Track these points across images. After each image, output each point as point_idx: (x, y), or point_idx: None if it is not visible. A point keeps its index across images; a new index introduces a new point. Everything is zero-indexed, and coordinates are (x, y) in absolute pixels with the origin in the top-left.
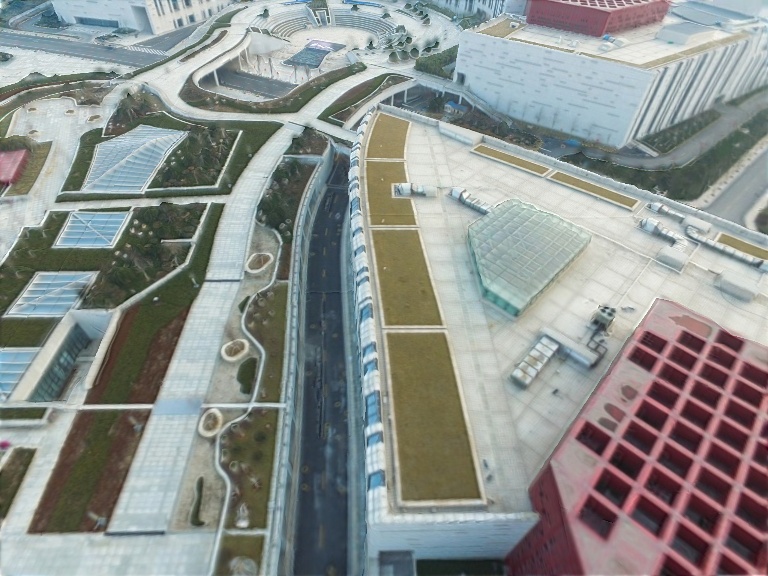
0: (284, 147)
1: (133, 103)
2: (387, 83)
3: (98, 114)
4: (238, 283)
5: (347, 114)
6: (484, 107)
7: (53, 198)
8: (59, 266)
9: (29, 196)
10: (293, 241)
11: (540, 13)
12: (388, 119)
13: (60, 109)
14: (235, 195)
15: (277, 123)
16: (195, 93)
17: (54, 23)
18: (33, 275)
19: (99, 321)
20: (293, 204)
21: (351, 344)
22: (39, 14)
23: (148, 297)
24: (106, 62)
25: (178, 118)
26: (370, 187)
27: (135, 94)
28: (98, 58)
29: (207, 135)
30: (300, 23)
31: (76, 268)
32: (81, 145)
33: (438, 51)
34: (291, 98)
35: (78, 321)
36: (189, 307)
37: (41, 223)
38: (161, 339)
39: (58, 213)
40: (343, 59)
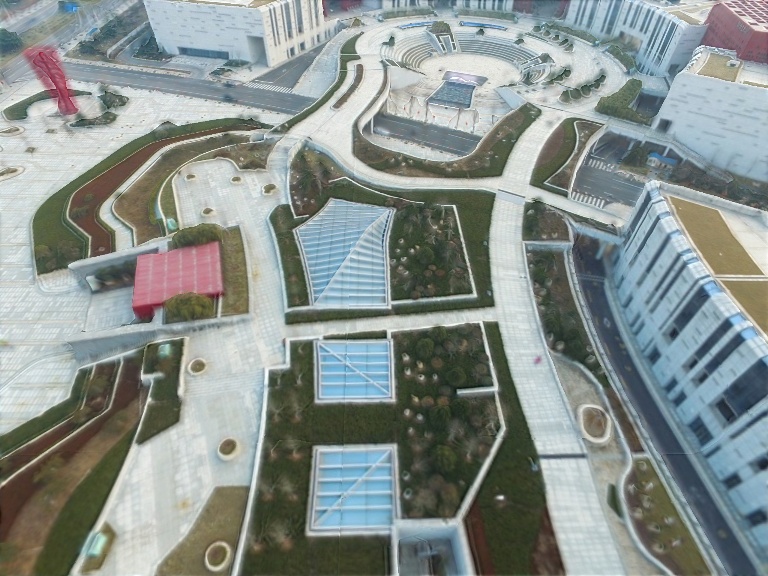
0: (516, 229)
1: (306, 166)
2: (583, 133)
3: (270, 182)
4: (585, 460)
5: (565, 179)
6: (699, 161)
7: (280, 317)
8: (340, 436)
9: (251, 315)
10: (610, 381)
11: (762, 48)
12: (687, 206)
13: (221, 175)
14: (502, 307)
15: (487, 192)
16: (373, 152)
17: (155, 54)
18: (311, 452)
19: (429, 533)
20: (575, 318)
21: (754, 551)
22: (133, 43)
23: (483, 491)
24: (233, 104)
25: (367, 187)
26: (766, 330)
27: (300, 152)
28: (222, 99)
29: (427, 216)
30: (424, 50)
31: (363, 439)
32: (276, 231)
33: (605, 86)
34: (487, 157)
35: (405, 536)
36: (546, 508)
37: (287, 361)
38: (542, 574)
39: (301, 344)
40: (494, 96)
